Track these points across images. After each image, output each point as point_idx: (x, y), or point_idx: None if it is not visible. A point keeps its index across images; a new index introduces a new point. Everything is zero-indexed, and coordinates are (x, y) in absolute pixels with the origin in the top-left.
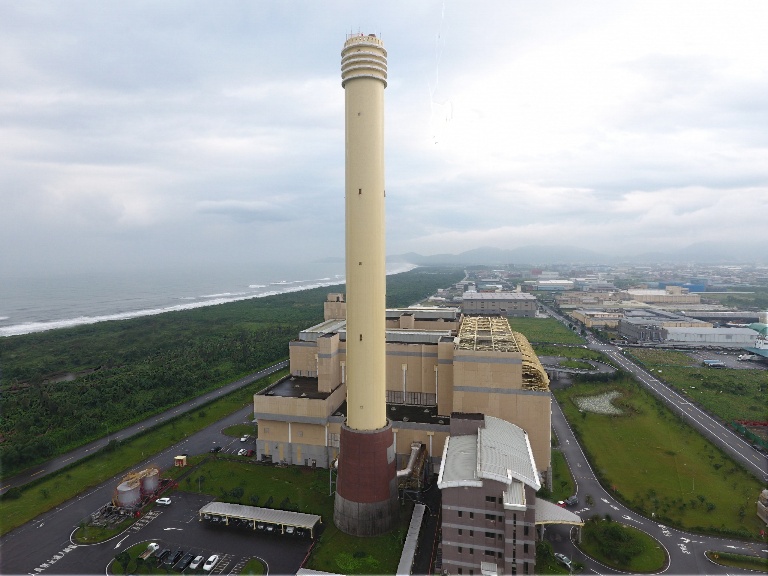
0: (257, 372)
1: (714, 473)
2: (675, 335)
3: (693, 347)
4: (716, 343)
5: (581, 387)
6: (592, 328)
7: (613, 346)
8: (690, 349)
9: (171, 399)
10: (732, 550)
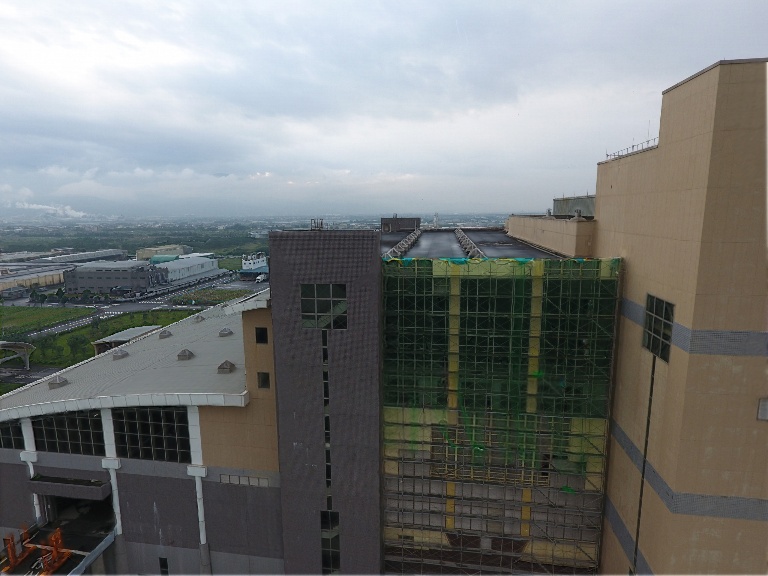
0: None
1: None
2: (173, 273)
3: (192, 283)
4: (200, 275)
5: None
6: (34, 291)
7: (135, 303)
8: (193, 286)
9: None
10: None
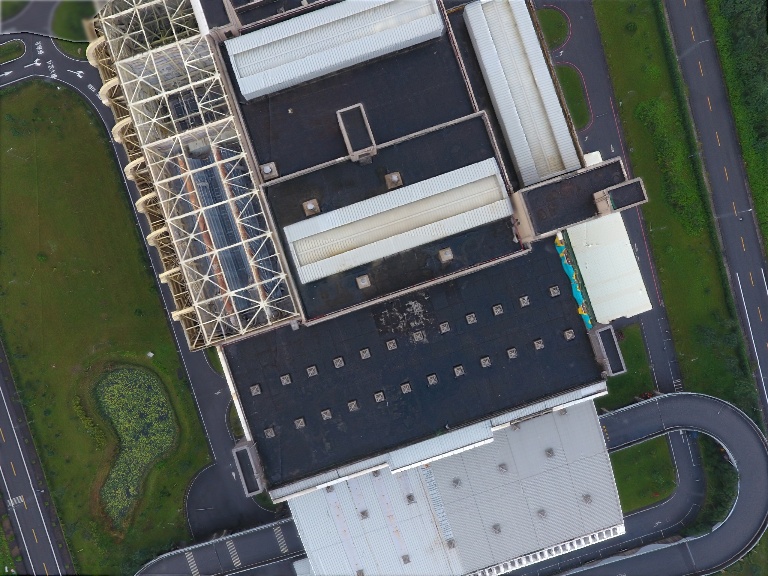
0: (767, 272)
1: (4, 223)
2: None
3: None
4: None
5: (170, 502)
6: None
7: None
8: None
9: (739, 44)
10: (7, 66)
